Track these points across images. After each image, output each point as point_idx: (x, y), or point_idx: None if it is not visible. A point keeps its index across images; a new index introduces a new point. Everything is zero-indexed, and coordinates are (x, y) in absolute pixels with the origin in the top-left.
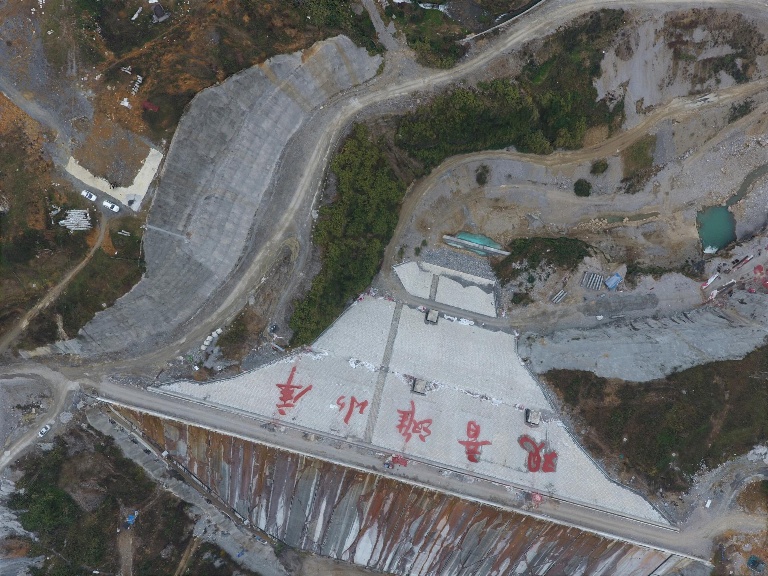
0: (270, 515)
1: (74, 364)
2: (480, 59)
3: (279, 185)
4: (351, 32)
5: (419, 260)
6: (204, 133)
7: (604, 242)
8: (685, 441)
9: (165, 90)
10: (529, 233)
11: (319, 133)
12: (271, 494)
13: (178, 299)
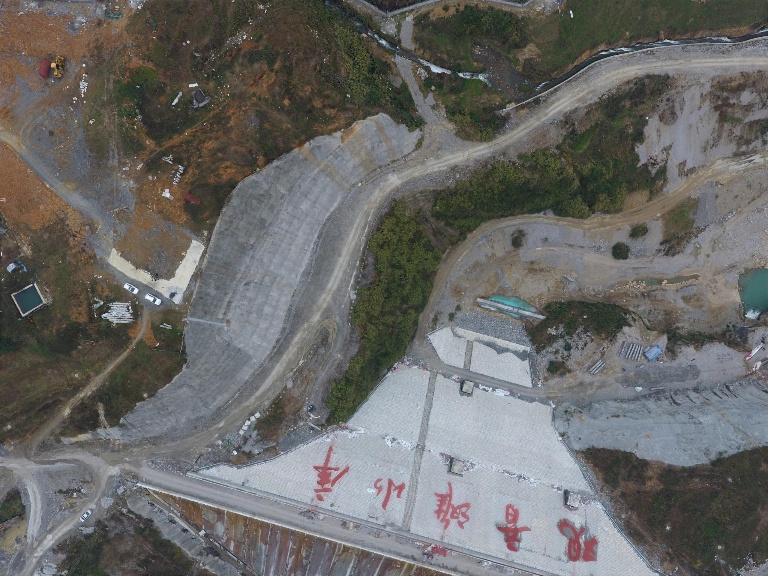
0: None
1: (114, 449)
2: (521, 130)
3: (317, 265)
4: (391, 110)
5: (453, 325)
6: (244, 221)
7: (642, 306)
8: (731, 533)
9: (206, 180)
10: (565, 296)
11: (357, 211)
12: (306, 572)
13: (217, 385)
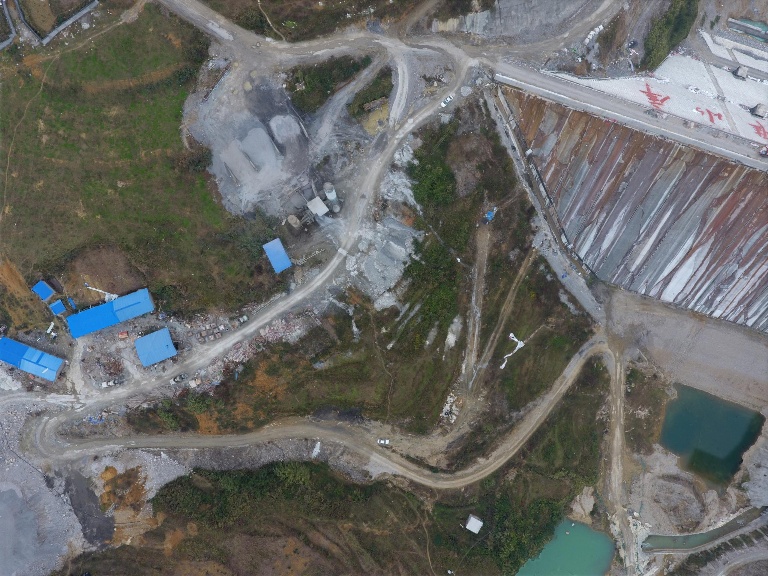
0: (599, 236)
1: (474, 43)
2: None
3: None
4: None
5: (713, 33)
6: None
7: None
8: None
9: None
10: None
11: None
12: (616, 204)
13: None
